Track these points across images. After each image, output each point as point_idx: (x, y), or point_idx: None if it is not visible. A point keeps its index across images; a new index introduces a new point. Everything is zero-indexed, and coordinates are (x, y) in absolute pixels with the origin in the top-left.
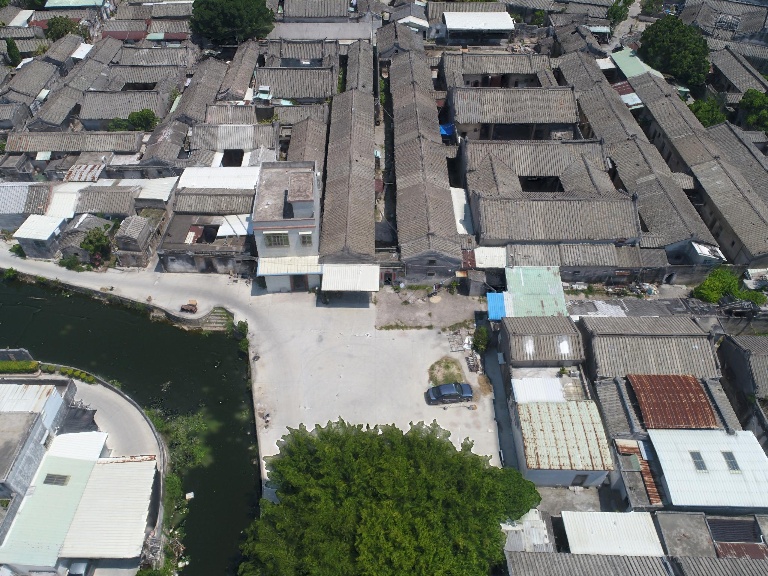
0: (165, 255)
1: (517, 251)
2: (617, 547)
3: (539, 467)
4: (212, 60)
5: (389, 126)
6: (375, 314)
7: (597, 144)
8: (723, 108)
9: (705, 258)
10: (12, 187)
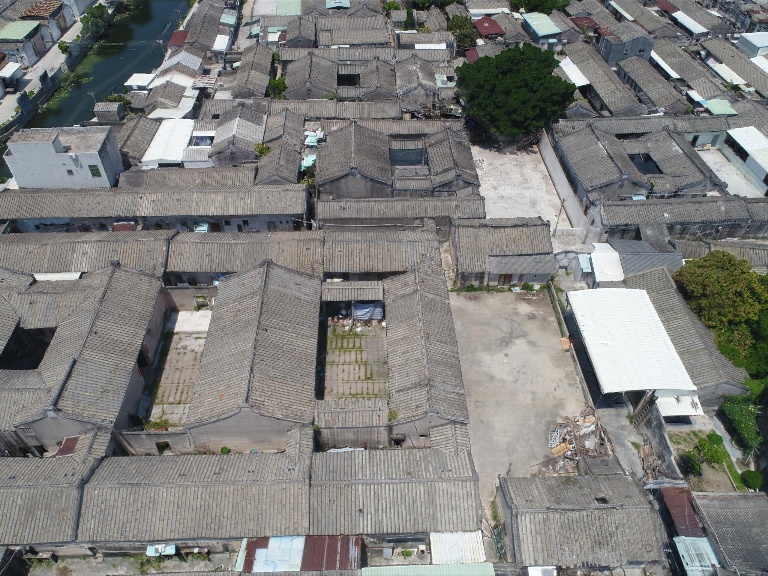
0: None
1: None
2: None
3: None
4: (397, 103)
5: None
6: None
7: None
8: None
9: None
10: None
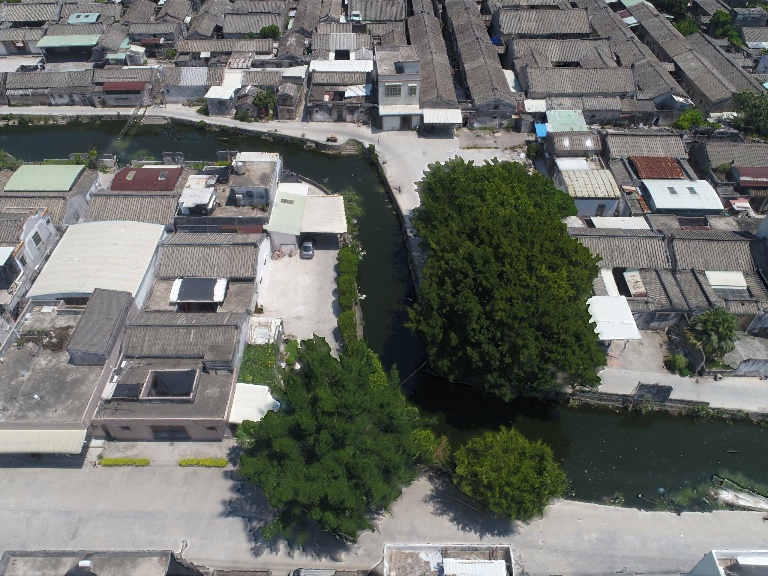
0: (312, 107)
1: (553, 101)
2: (624, 228)
3: (576, 196)
4: None
5: (448, 42)
6: (458, 142)
7: (606, 40)
8: (699, 27)
9: (681, 104)
10: (196, 68)
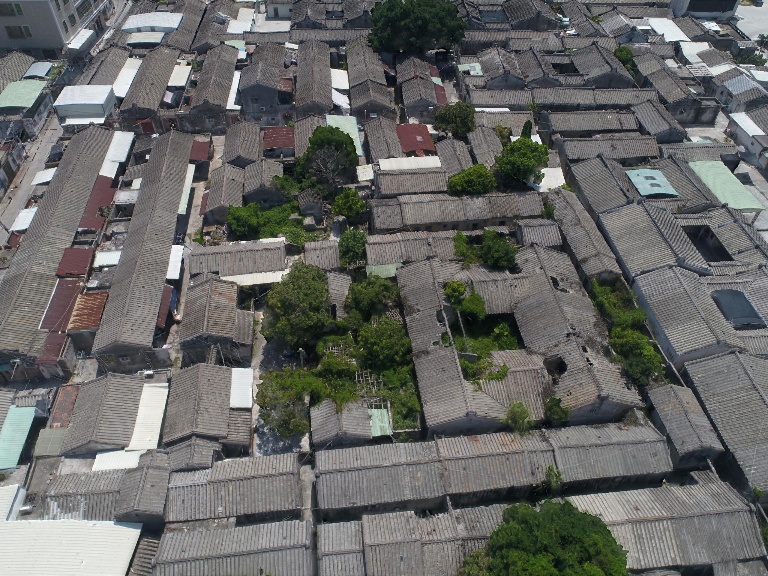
0: None
1: None
2: None
3: None
4: None
5: None
6: None
7: None
8: None
9: None
10: None
